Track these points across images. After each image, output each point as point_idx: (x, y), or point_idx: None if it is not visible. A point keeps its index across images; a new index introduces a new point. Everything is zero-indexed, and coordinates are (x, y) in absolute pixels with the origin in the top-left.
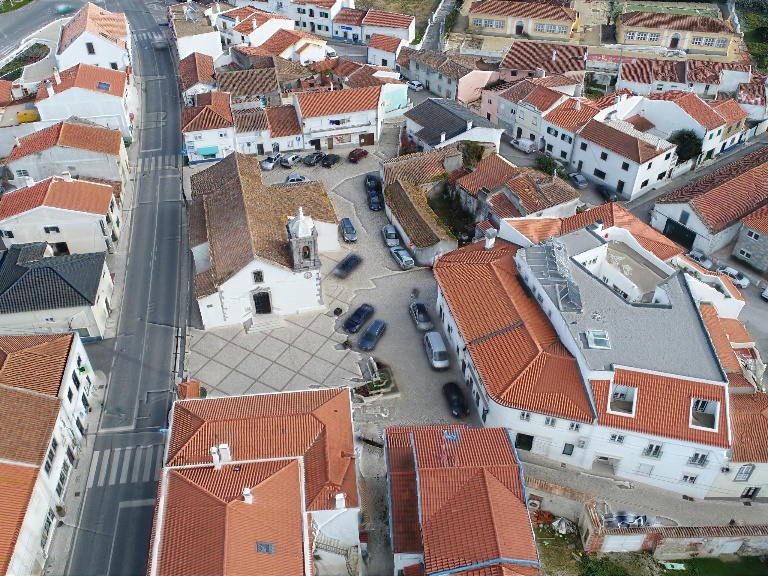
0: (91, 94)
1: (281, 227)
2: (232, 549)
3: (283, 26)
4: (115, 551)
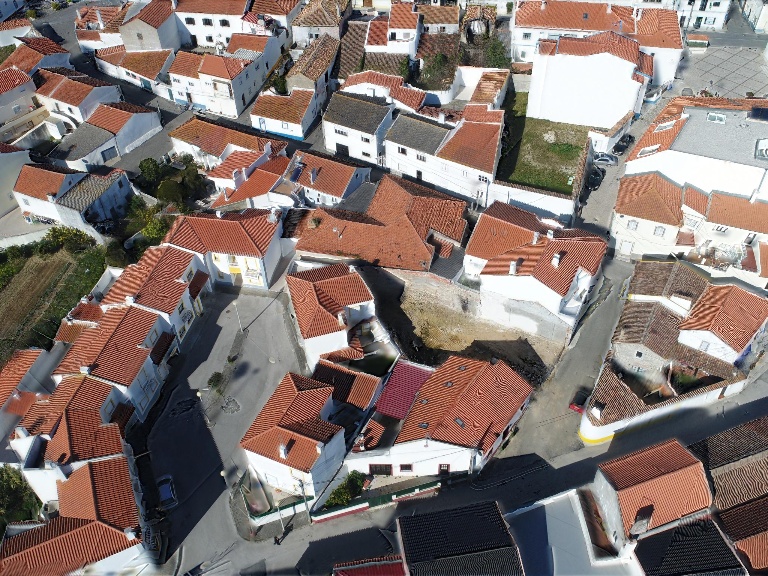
0: None
1: None
2: (584, 5)
3: None
4: None
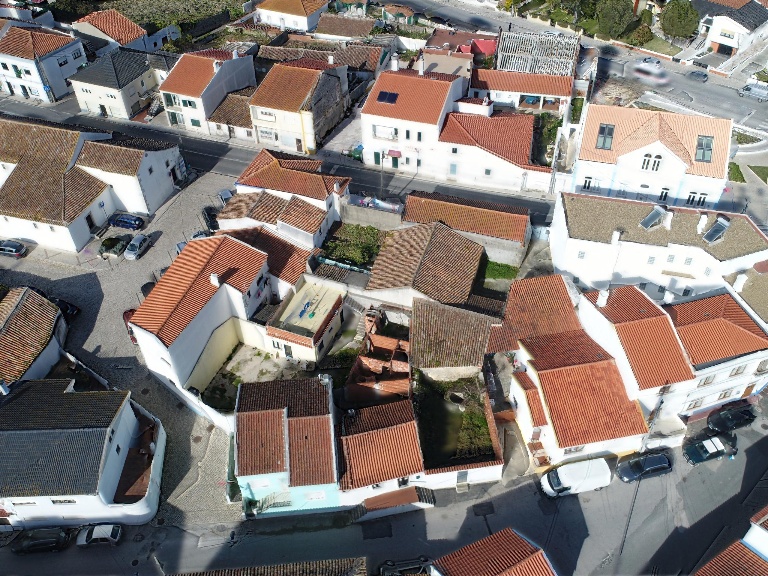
0: None
1: (1, 153)
2: None
3: None
4: None
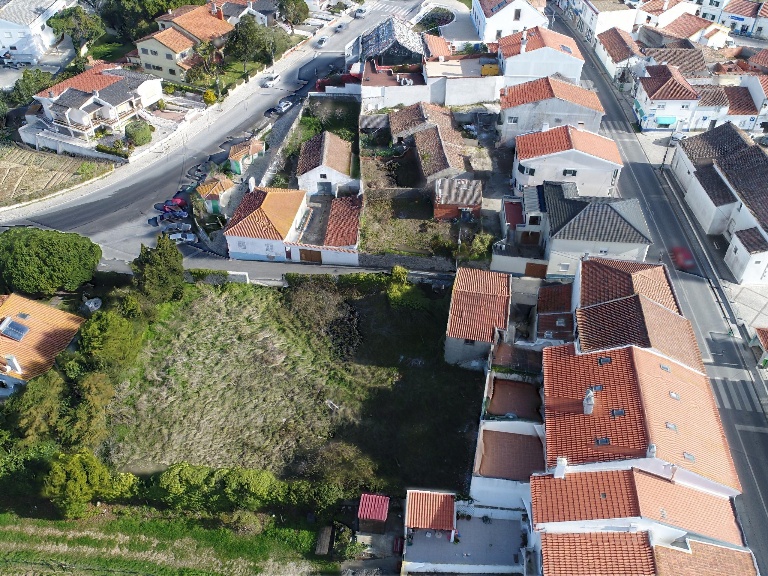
0: (559, 55)
1: None
2: None
3: (688, 10)
4: (754, 466)
